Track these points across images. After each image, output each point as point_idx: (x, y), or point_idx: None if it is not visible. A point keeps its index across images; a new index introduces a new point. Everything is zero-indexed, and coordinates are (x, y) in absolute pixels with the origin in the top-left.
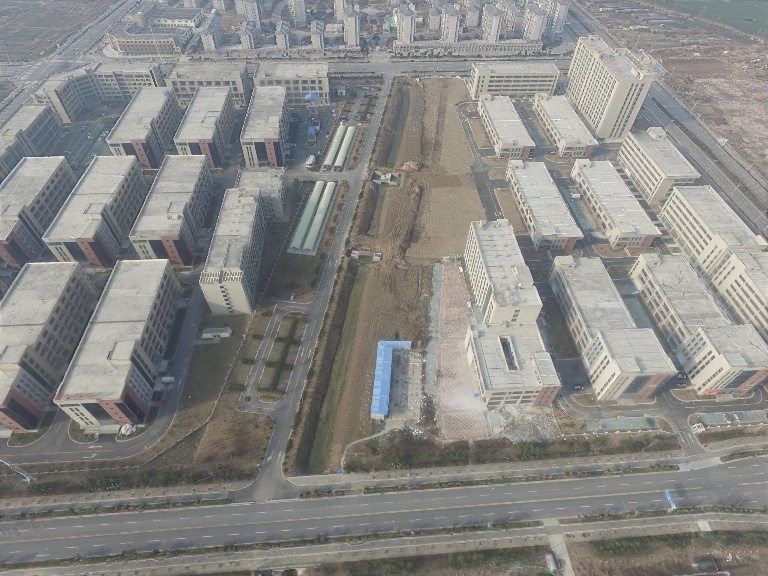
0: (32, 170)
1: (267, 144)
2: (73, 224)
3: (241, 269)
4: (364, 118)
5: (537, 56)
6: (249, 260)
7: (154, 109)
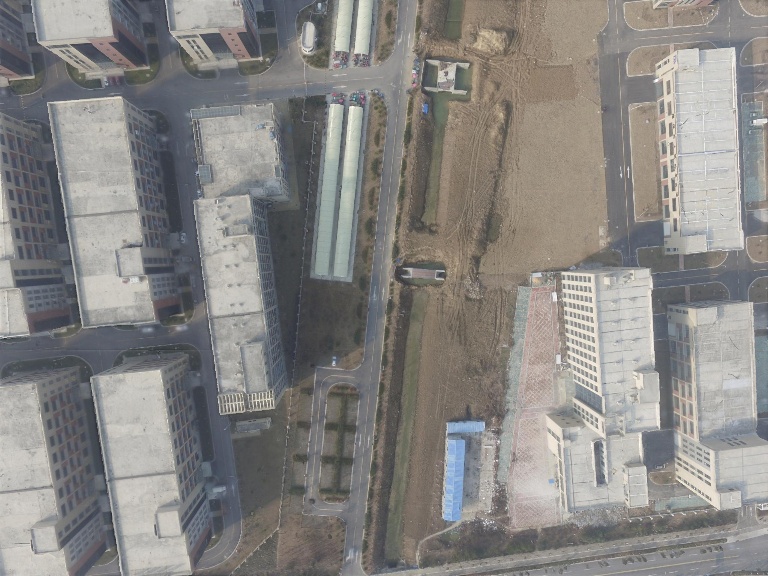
0: None
1: (225, 35)
2: None
3: (269, 383)
4: None
5: None
6: (271, 346)
7: None
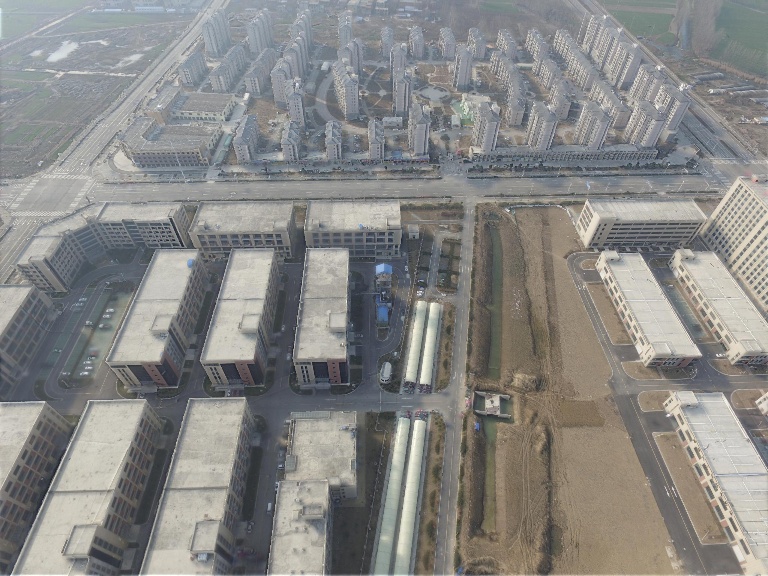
0: None
1: (330, 364)
2: (45, 572)
3: None
4: (448, 283)
5: (651, 168)
6: None
7: (174, 294)
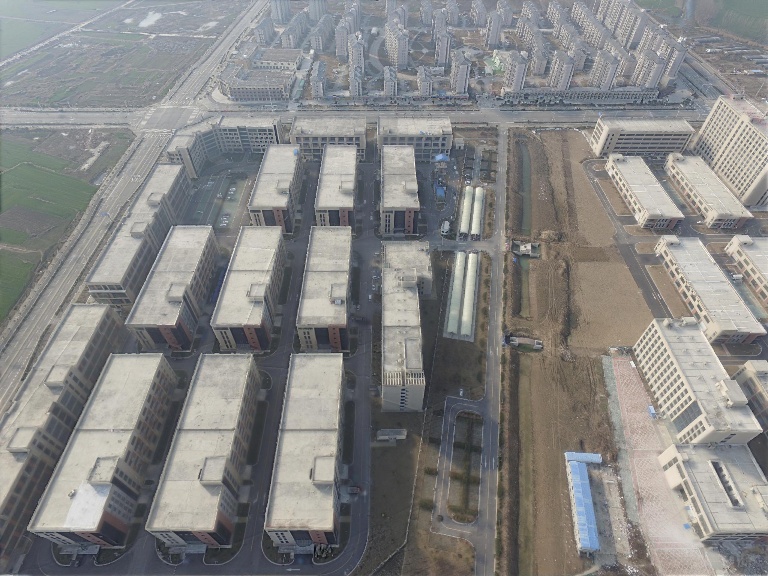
0: (183, 241)
1: (407, 213)
2: (237, 307)
3: None
4: (489, 177)
5: (653, 105)
6: None
7: (287, 170)
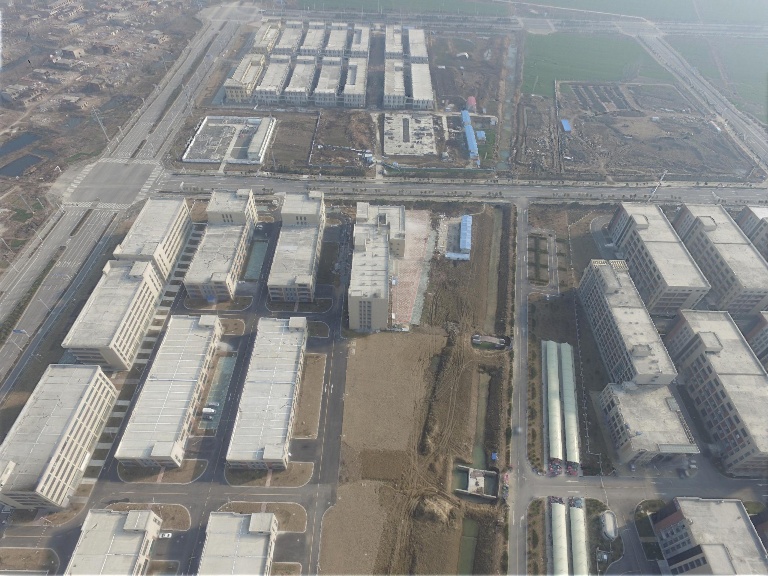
0: None
1: None
2: None
3: None
4: None
5: None
6: None
7: None
